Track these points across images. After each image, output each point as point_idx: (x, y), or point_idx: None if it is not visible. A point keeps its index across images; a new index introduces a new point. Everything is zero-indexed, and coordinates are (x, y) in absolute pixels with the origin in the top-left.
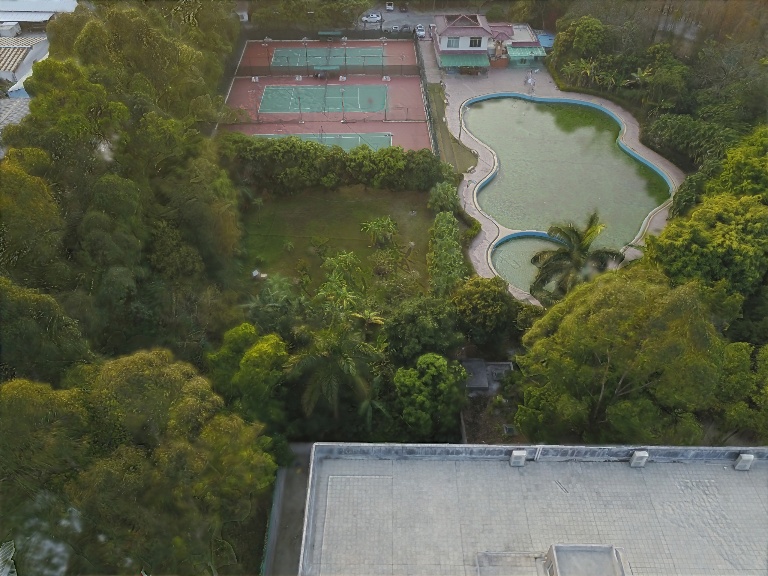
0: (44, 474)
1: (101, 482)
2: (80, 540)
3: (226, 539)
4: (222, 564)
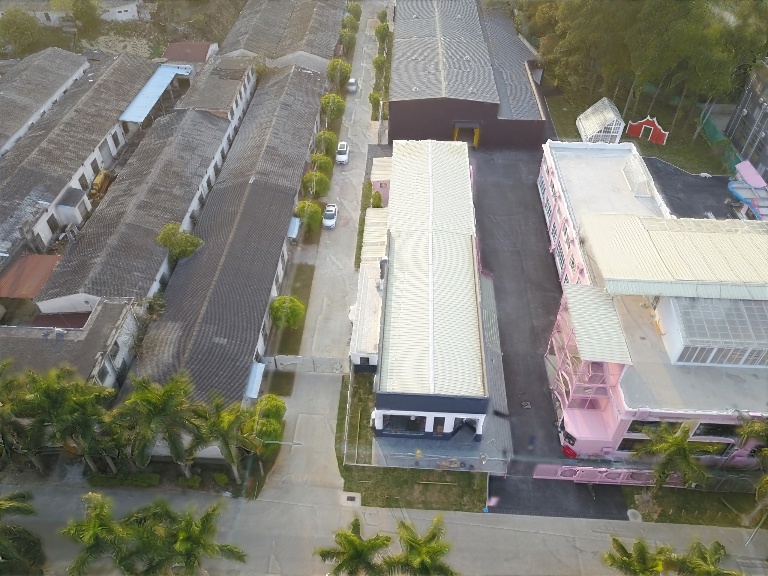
0: (727, 6)
1: (758, 2)
2: (738, 32)
3: (681, 132)
4: (760, 68)
